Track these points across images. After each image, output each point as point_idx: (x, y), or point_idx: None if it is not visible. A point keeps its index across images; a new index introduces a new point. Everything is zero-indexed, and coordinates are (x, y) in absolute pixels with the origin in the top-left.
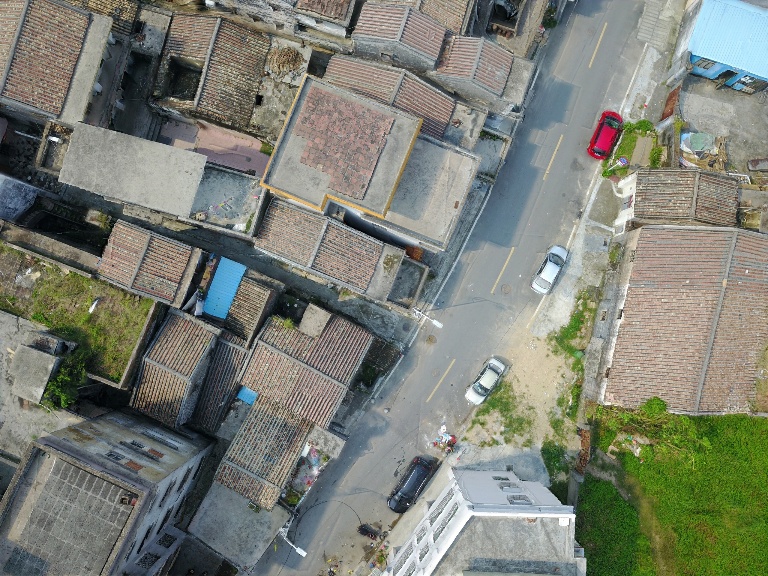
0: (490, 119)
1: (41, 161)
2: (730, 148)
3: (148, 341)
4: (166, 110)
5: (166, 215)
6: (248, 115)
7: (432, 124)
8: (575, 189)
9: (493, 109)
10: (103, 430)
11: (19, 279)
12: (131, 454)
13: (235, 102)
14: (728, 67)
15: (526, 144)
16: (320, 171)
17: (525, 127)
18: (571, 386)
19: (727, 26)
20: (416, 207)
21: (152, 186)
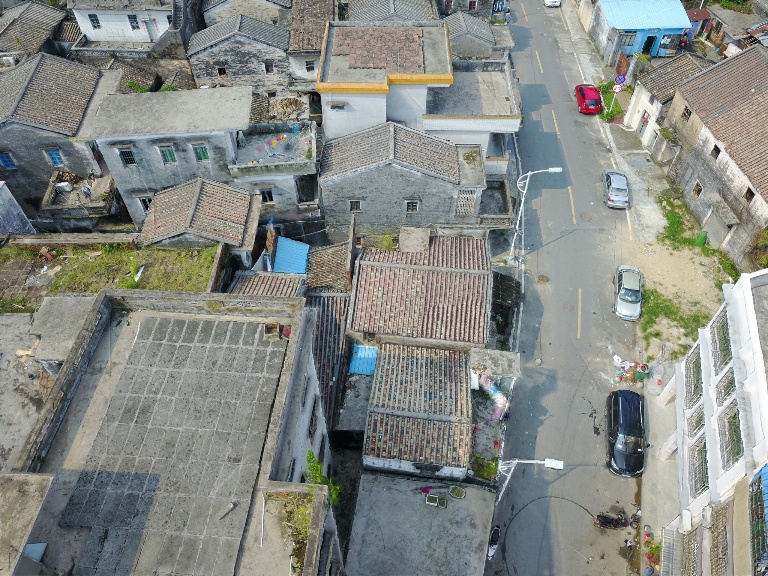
0: None
1: None
2: None
3: None
4: None
5: None
6: None
7: None
8: (591, 137)
9: None
10: None
11: (31, 280)
12: None
13: None
14: (647, 32)
15: (527, 122)
16: (372, 69)
17: None
18: (718, 269)
19: (627, 10)
20: (471, 109)
21: (199, 116)
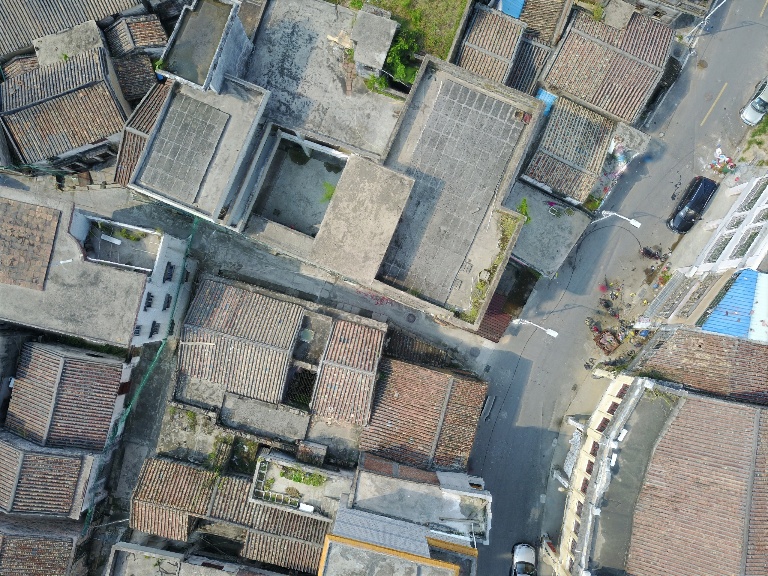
0: None
1: None
2: None
3: (465, 28)
4: None
5: None
6: None
7: None
8: None
9: None
10: None
11: None
12: None
13: None
14: None
15: None
16: None
17: None
18: None
19: None
20: None
21: None
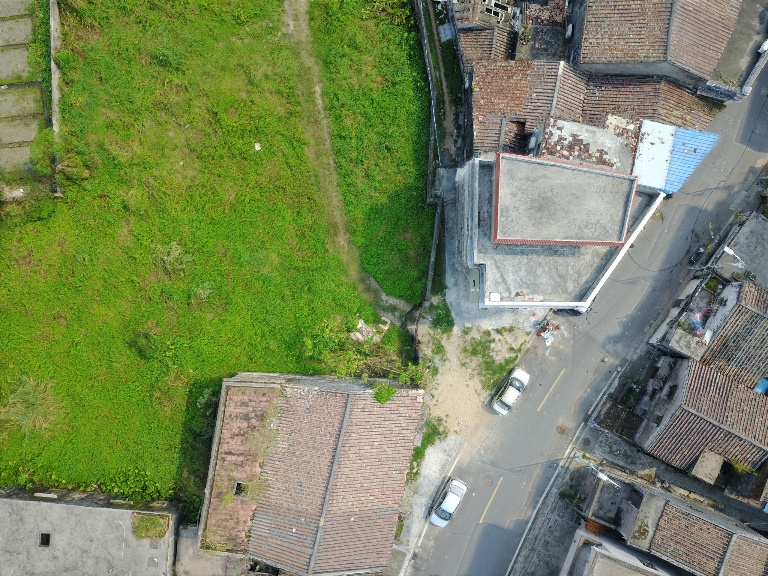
0: None
1: None
2: None
3: None
4: None
5: None
6: None
7: None
8: None
9: None
10: None
11: None
12: None
13: None
14: None
15: None
16: None
17: None
18: None
19: None
20: None
21: None
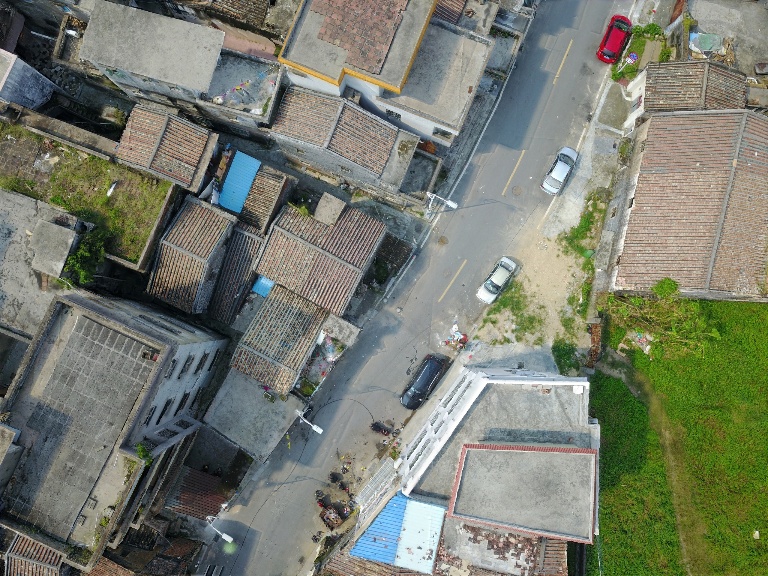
0: (501, 19)
1: (58, 54)
2: (737, 53)
3: (165, 225)
4: (181, 10)
5: (183, 103)
6: (262, 15)
7: (446, 13)
8: (585, 93)
9: (505, 5)
10: (122, 306)
11: (38, 164)
12: (151, 325)
13: (250, 1)
14: None
15: (536, 49)
16: (337, 47)
17: (535, 32)
18: (581, 285)
19: None
20: (430, 92)
21: (171, 61)
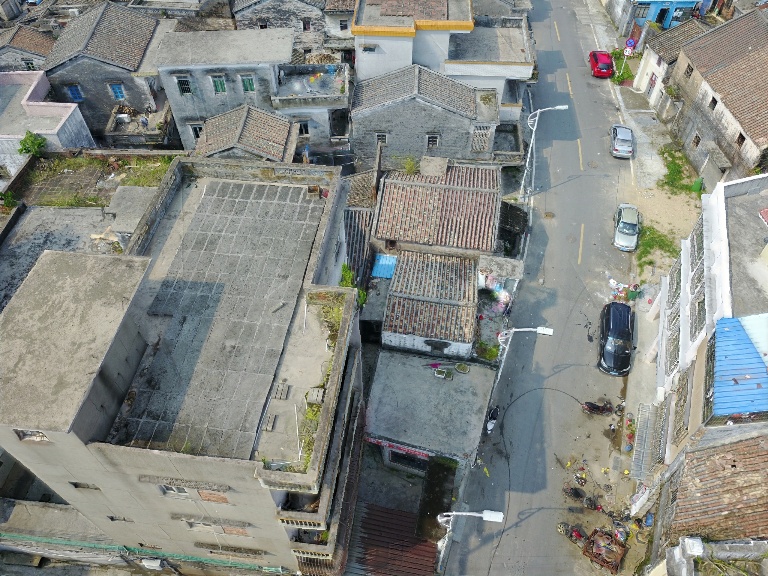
0: None
1: None
2: None
3: None
4: None
5: None
6: None
7: None
8: (601, 97)
9: None
10: None
11: (101, 184)
12: None
13: None
14: (660, 5)
15: (542, 83)
16: (401, 17)
17: None
18: None
19: None
20: (489, 58)
21: (248, 50)
